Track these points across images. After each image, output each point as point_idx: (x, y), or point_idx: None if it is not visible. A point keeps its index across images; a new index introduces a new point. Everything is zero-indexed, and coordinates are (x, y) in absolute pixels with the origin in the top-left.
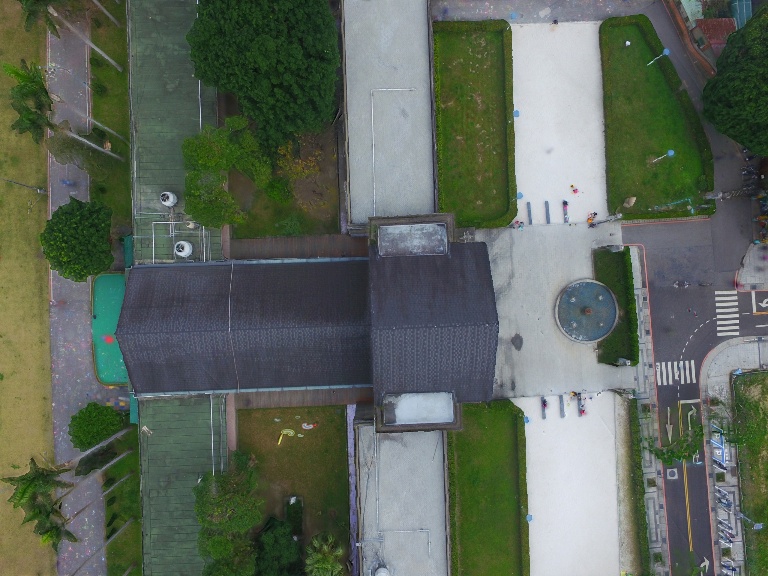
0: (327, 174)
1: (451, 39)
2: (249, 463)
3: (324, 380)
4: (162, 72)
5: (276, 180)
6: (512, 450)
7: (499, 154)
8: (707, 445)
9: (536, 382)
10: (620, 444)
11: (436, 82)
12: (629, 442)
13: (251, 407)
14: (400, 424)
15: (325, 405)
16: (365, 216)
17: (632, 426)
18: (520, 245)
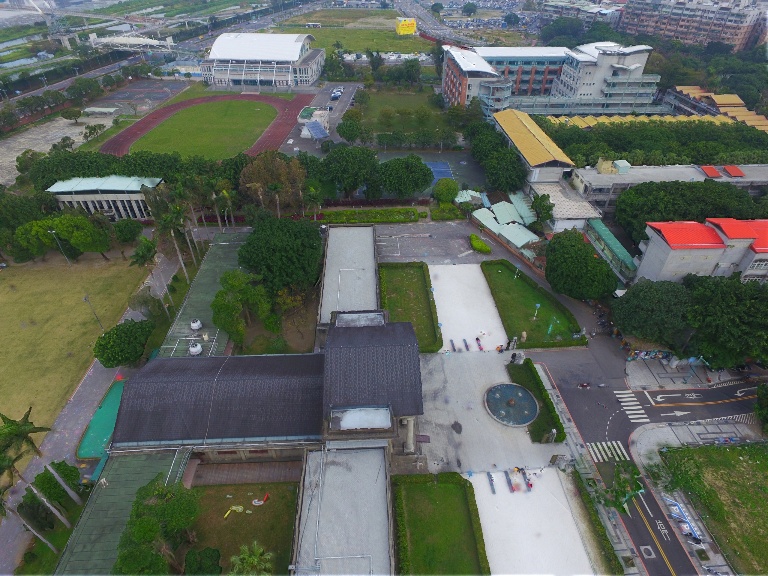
0: (308, 327)
1: (392, 271)
2: None
3: (283, 430)
4: (216, 275)
5: None
6: (467, 527)
7: (427, 317)
8: (670, 520)
9: (480, 460)
10: (579, 519)
11: (383, 285)
12: (587, 516)
13: (207, 484)
14: (344, 431)
15: (279, 482)
16: None
17: (582, 496)
18: (449, 363)
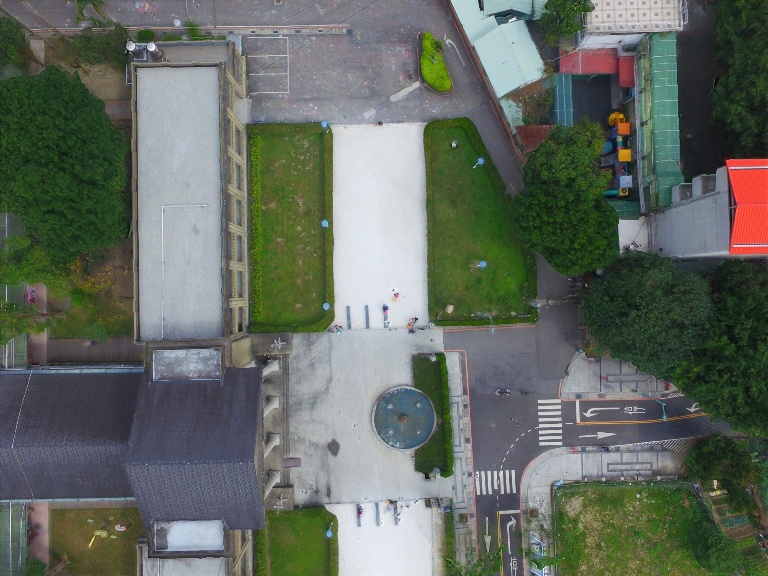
0: None
1: (273, 140)
2: (57, 566)
3: (119, 492)
4: None
5: (78, 288)
6: (326, 557)
7: (320, 257)
8: (526, 557)
9: (352, 489)
10: (436, 554)
11: (255, 184)
12: (445, 552)
13: (65, 507)
14: (170, 551)
15: None
16: (154, 333)
17: (447, 537)
18: (339, 349)
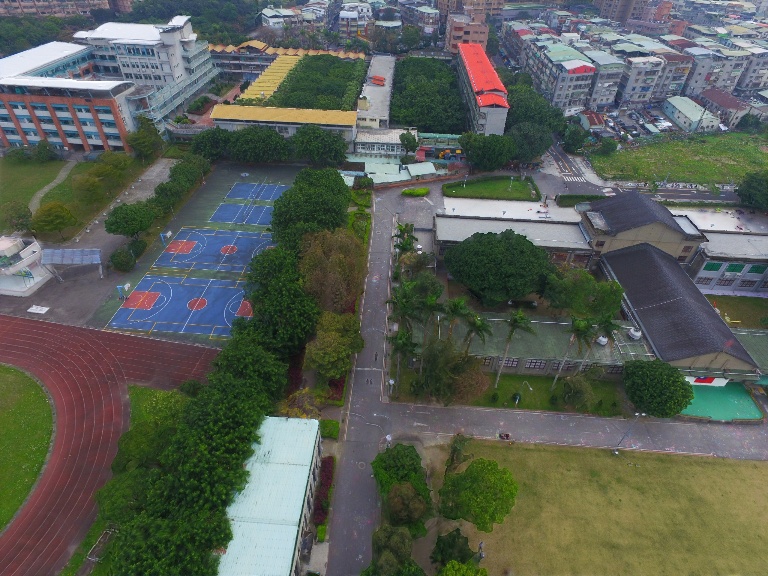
0: None
1: None
2: None
3: (687, 277)
4: None
5: None
6: None
7: None
8: None
9: None
10: None
11: None
12: None
13: None
14: (699, 232)
15: None
16: (585, 246)
17: None
18: None
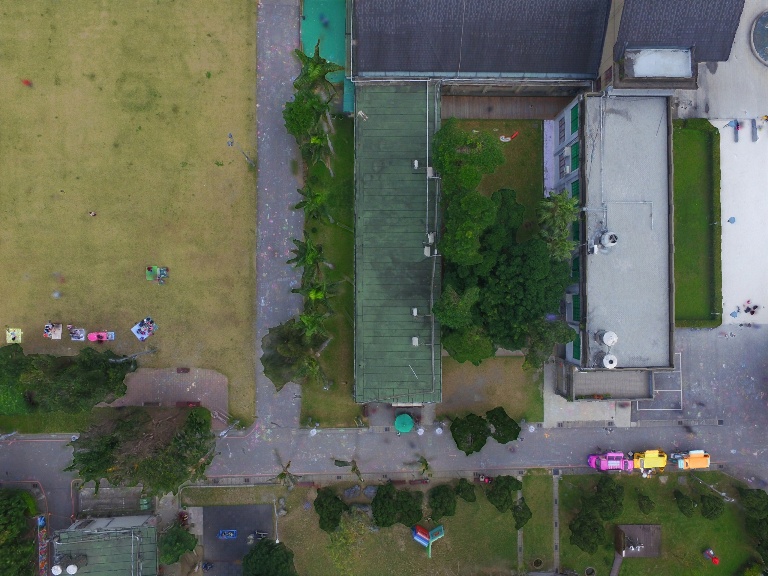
0: None
1: None
2: None
3: (543, 66)
4: None
5: None
6: (704, 171)
7: None
8: None
9: (729, 105)
10: None
11: None
12: None
13: None
14: (640, 78)
15: (523, 119)
16: None
17: None
18: None
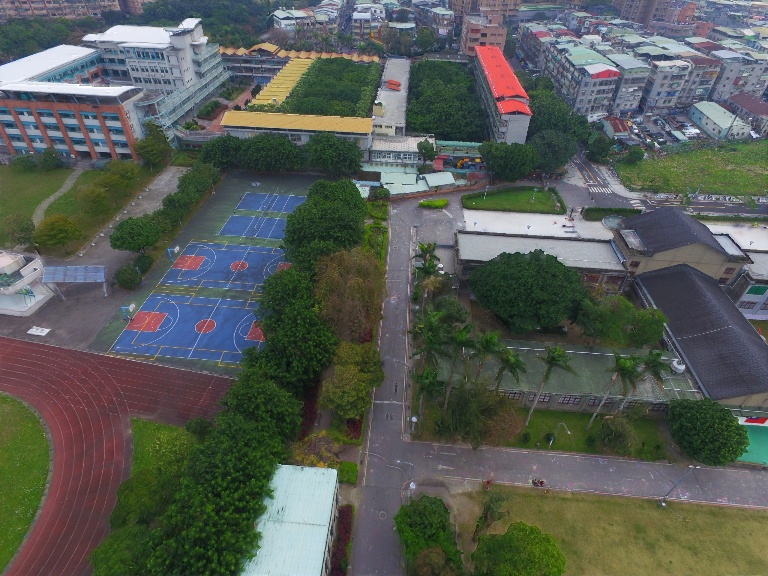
0: None
1: None
2: None
3: (730, 302)
4: (539, 372)
5: None
6: None
7: None
8: None
9: None
10: None
11: None
12: None
13: None
14: (743, 253)
15: None
16: (619, 267)
17: None
18: None
